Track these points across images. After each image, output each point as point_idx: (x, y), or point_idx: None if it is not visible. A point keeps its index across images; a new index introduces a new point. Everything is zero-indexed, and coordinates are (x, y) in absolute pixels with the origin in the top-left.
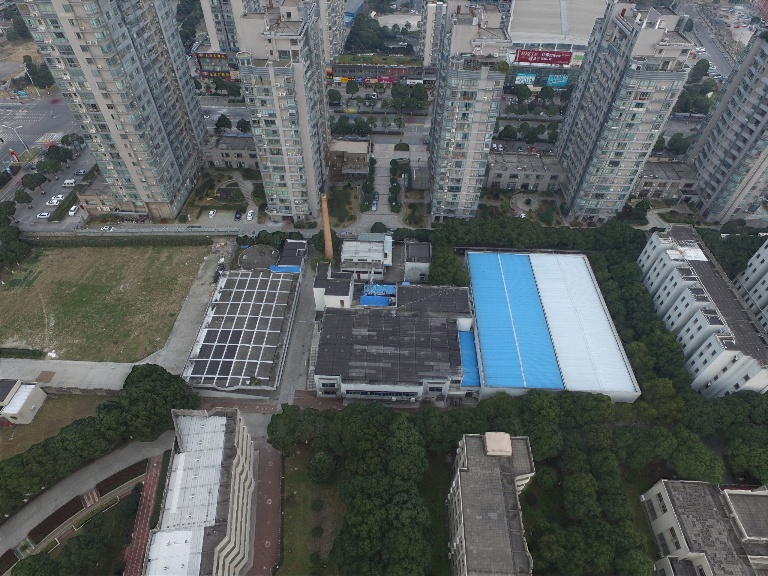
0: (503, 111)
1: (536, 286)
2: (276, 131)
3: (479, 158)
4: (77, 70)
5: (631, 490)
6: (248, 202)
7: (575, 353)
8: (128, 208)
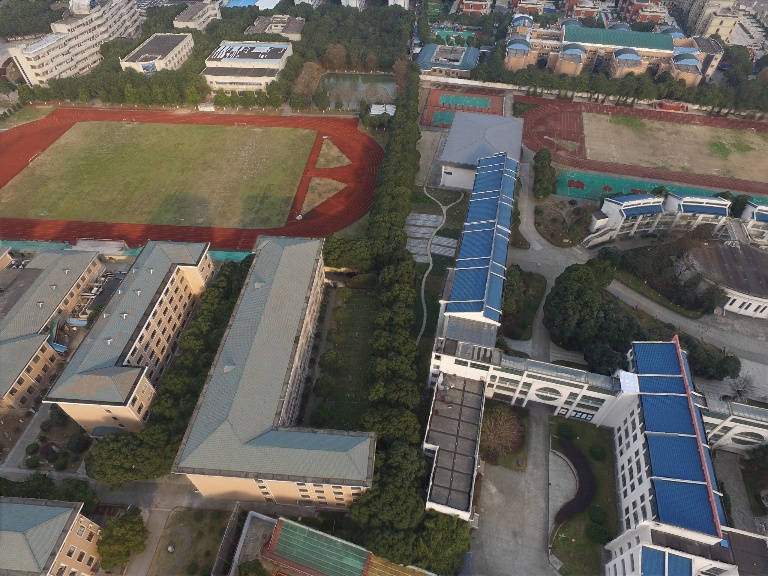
0: None
1: None
2: None
3: None
4: None
5: None
6: None
7: (260, 5)
8: None
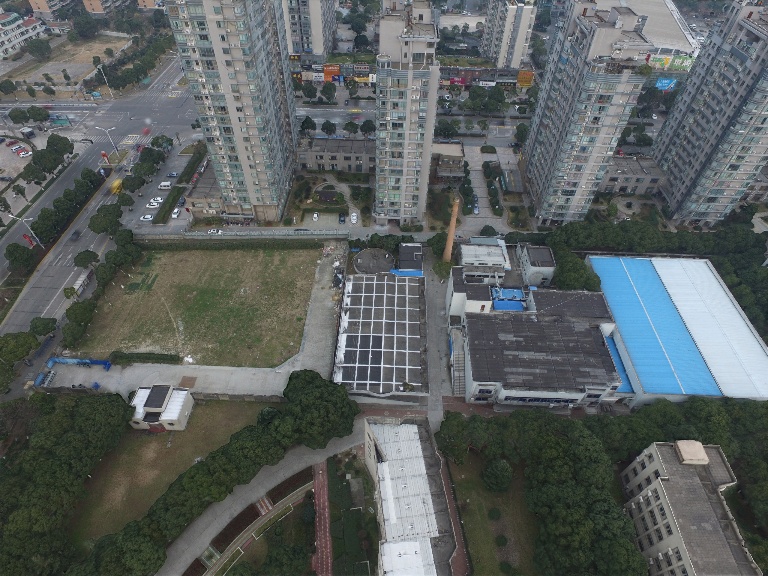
0: None
1: (666, 291)
2: (402, 134)
3: (600, 162)
4: (214, 72)
5: None
6: (348, 205)
7: (724, 359)
8: (235, 211)
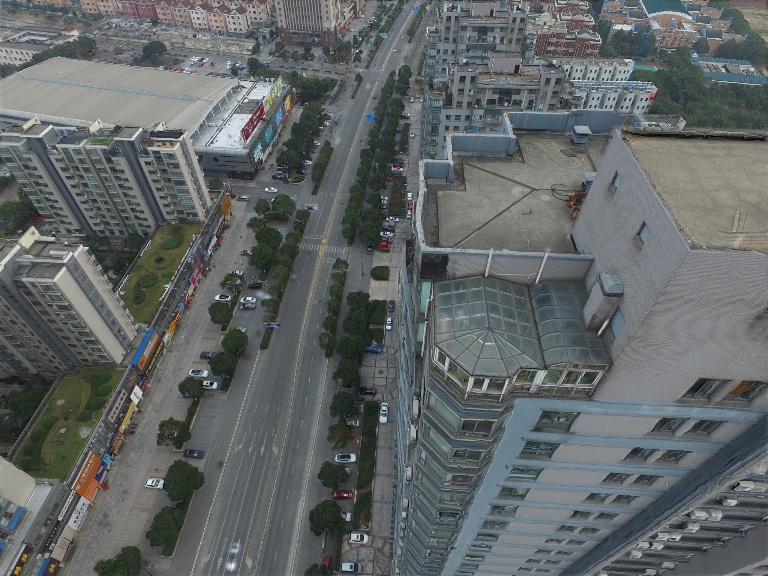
0: (315, 182)
1: None
2: None
3: None
4: None
5: None
6: None
7: None
8: None
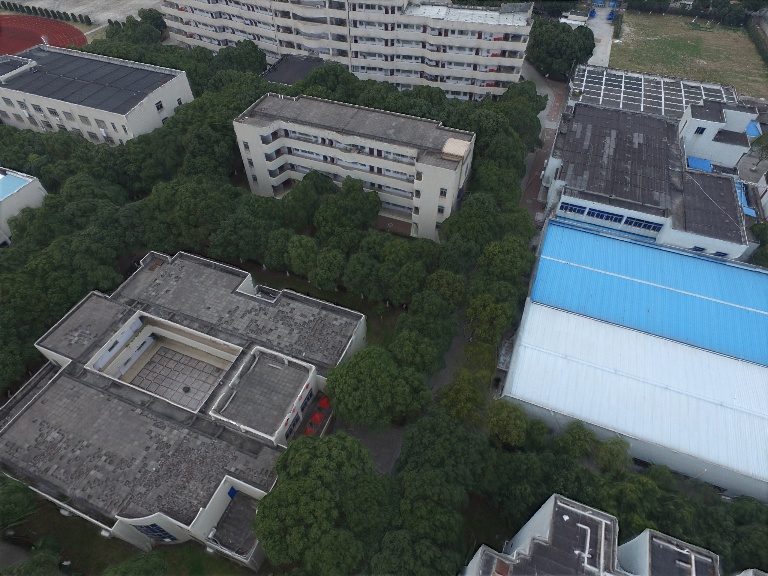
0: None
1: None
2: None
3: None
4: None
5: (378, 345)
6: None
7: (604, 347)
8: None
